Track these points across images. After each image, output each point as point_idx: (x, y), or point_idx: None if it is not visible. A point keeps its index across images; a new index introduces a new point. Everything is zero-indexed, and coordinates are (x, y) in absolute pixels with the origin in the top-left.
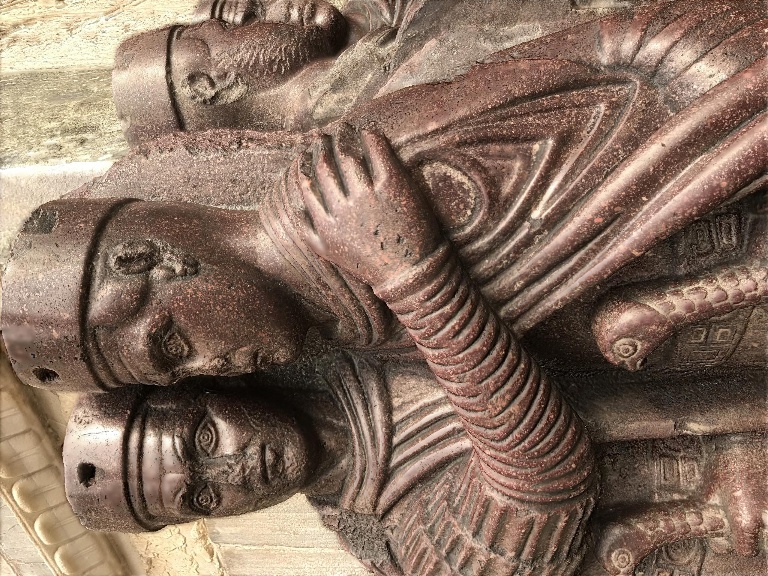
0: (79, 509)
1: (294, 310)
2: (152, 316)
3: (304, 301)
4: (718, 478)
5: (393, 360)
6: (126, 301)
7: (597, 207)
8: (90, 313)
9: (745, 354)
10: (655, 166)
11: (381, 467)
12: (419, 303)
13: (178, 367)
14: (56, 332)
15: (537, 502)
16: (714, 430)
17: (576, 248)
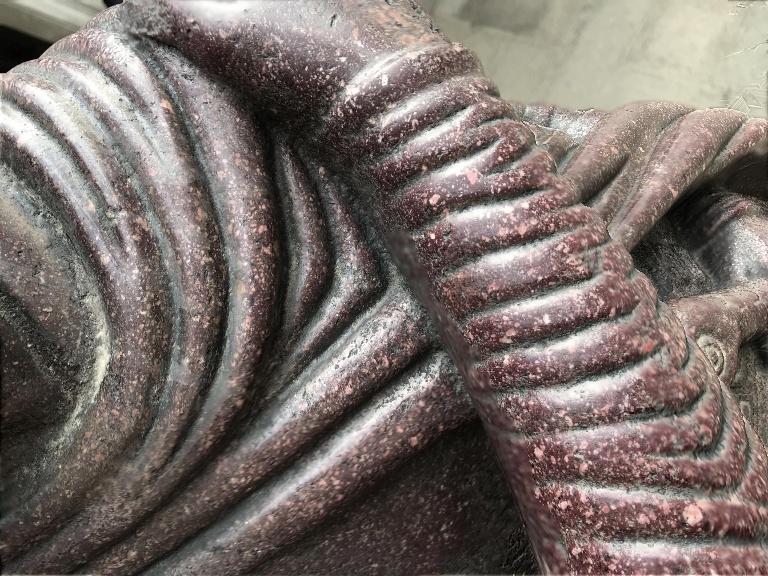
0: None
1: None
2: None
3: None
4: None
5: None
6: None
7: (605, 138)
8: None
9: None
10: (635, 121)
11: None
12: (477, 92)
13: None
14: None
15: None
16: None
17: (604, 178)
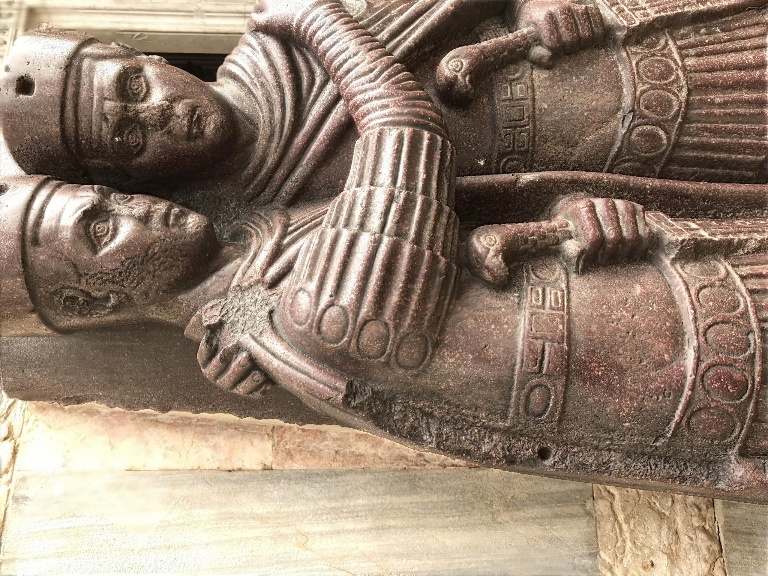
0: None
1: (229, 108)
2: (130, 62)
3: (237, 112)
4: (557, 213)
5: (294, 207)
6: (116, 51)
7: None
8: (87, 49)
9: (544, 121)
10: None
11: (275, 241)
12: (324, 10)
13: (132, 105)
14: (57, 49)
15: (405, 125)
16: (541, 175)
17: (417, 14)
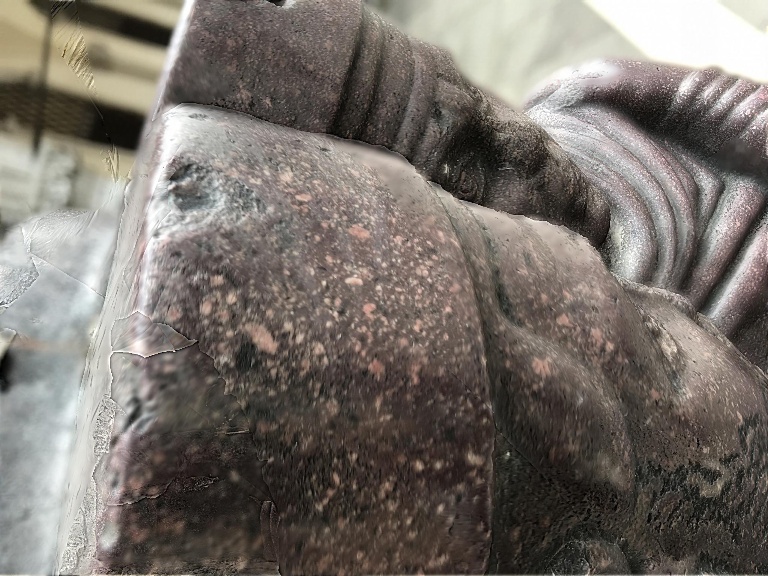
0: (221, 147)
1: None
2: None
3: None
4: None
5: None
6: None
7: None
8: None
9: None
10: None
11: None
12: None
13: None
14: None
15: None
16: None
17: None
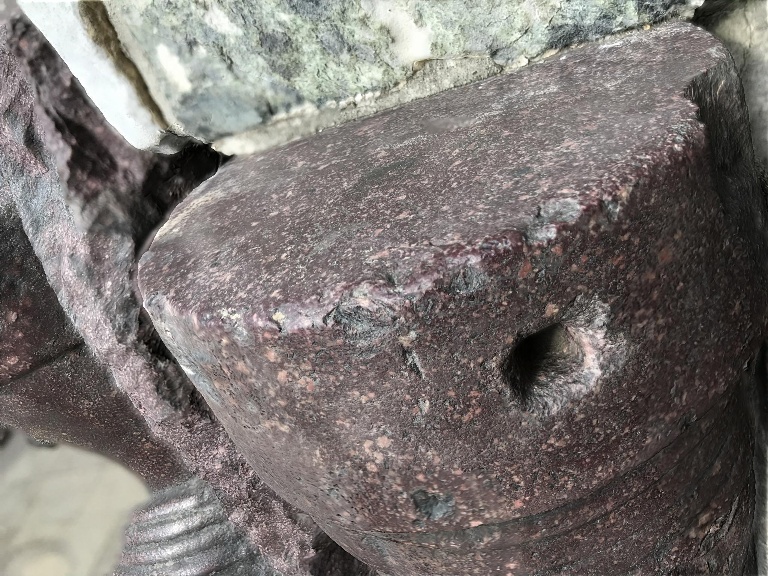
0: None
1: None
2: None
3: None
4: None
5: None
6: None
7: None
8: None
9: None
10: None
11: None
12: None
13: None
14: None
15: None
16: None
17: None
